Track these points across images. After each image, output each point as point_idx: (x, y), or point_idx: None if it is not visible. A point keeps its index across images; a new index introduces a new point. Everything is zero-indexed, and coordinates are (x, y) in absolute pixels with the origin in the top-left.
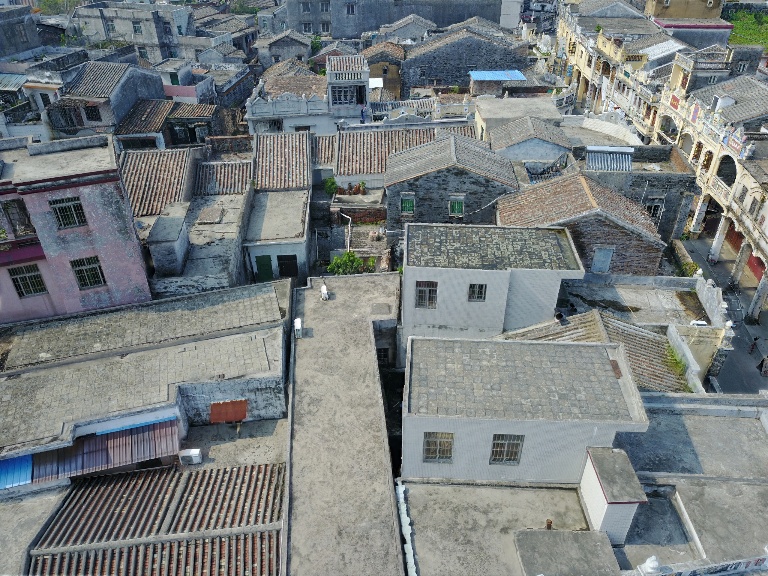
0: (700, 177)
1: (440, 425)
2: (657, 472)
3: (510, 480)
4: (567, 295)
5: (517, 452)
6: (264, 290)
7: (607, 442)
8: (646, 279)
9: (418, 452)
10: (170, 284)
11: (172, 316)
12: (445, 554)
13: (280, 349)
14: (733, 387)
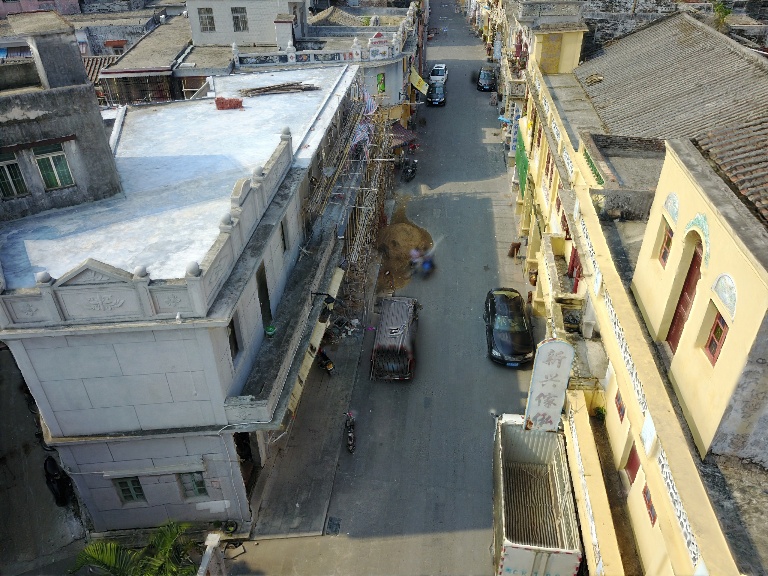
0: (495, 13)
1: (204, 2)
2: (320, 37)
3: (247, 44)
4: (325, 8)
5: (246, 22)
6: (148, 10)
7: (286, 10)
8: (382, 10)
9: (198, 24)
10: (93, 8)
11: (91, 15)
12: (202, 56)
13: (148, 20)
14: (467, 108)
